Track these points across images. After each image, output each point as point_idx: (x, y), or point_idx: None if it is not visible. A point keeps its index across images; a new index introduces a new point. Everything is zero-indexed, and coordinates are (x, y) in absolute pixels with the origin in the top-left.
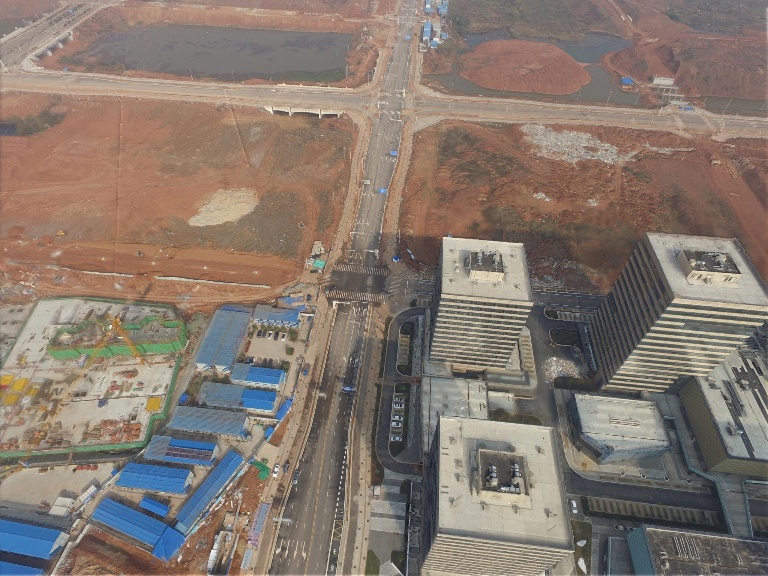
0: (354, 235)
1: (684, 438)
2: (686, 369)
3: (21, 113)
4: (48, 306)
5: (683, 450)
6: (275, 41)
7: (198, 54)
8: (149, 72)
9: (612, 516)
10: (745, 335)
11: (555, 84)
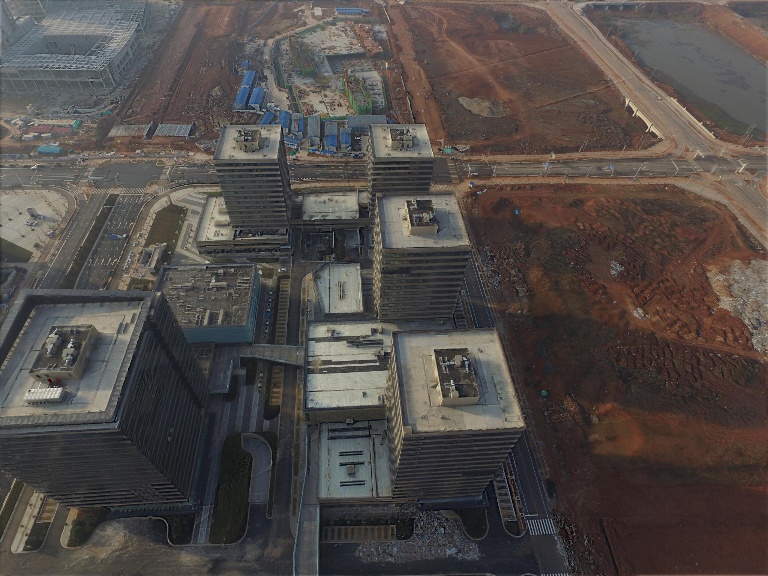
0: (489, 163)
1: None
2: None
3: (527, 22)
4: (374, 74)
5: None
6: None
7: (684, 57)
8: (623, 44)
9: (278, 289)
10: None
11: None
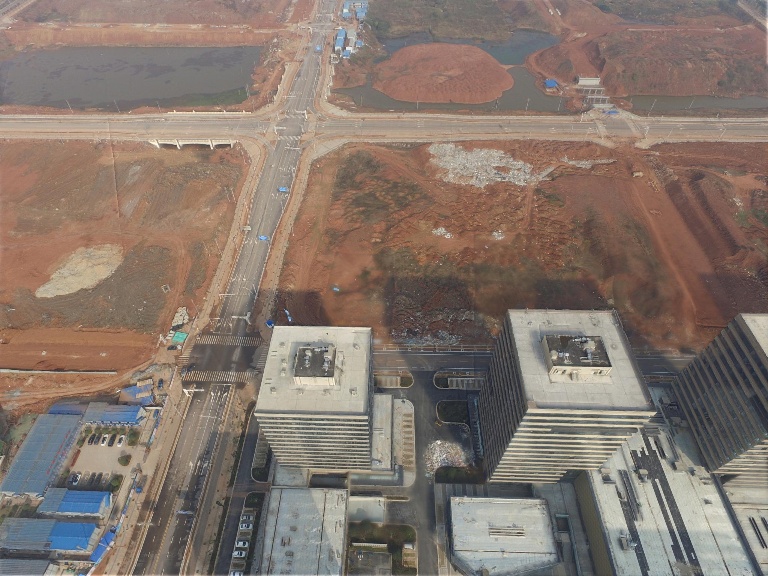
0: (227, 295)
1: (578, 543)
2: (572, 465)
3: None
4: None
5: (576, 561)
6: (177, 59)
7: (87, 80)
8: (25, 106)
9: None
10: (626, 436)
11: (473, 92)
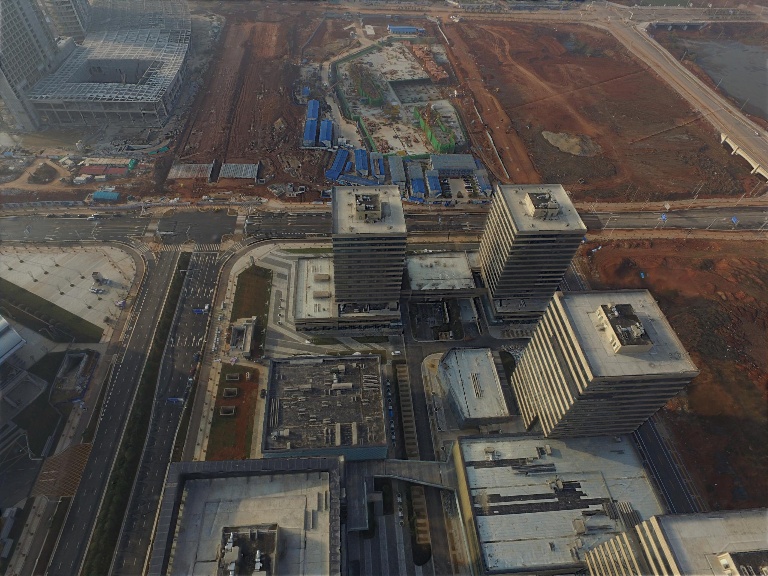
0: (595, 213)
1: None
2: (541, 409)
3: (591, 43)
4: (445, 103)
5: None
6: None
7: (765, 85)
8: (699, 69)
9: None
10: (572, 397)
11: None
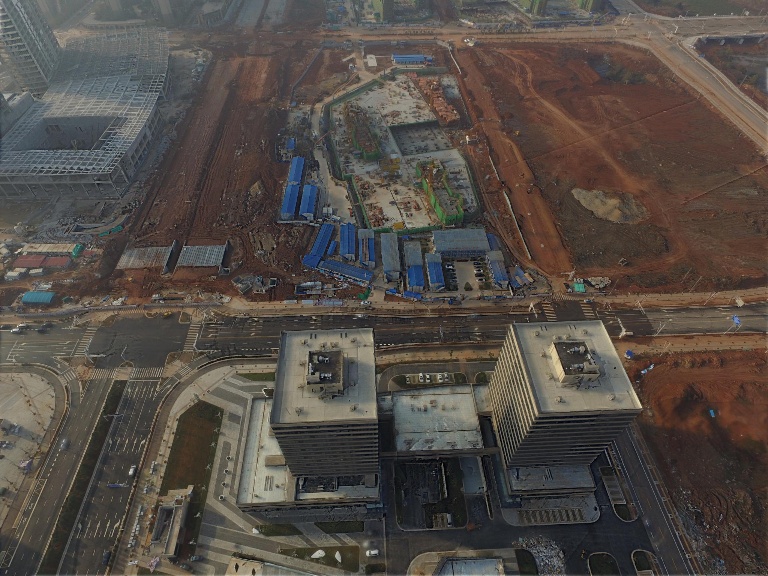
0: None
1: None
2: None
3: (629, 66)
4: (454, 154)
5: None
6: None
7: None
8: (763, 96)
9: None
10: None
11: None
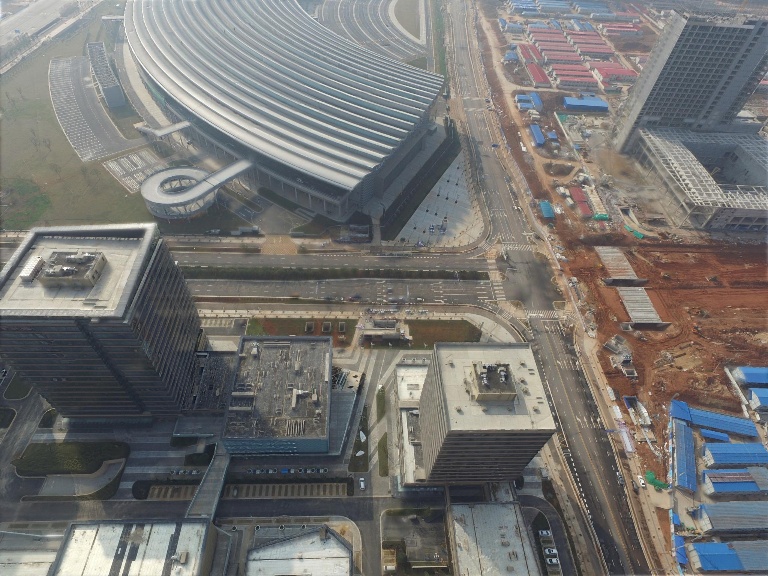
0: None
1: None
2: None
3: None
4: None
5: None
6: None
7: None
8: None
9: (328, 480)
10: None
11: None
